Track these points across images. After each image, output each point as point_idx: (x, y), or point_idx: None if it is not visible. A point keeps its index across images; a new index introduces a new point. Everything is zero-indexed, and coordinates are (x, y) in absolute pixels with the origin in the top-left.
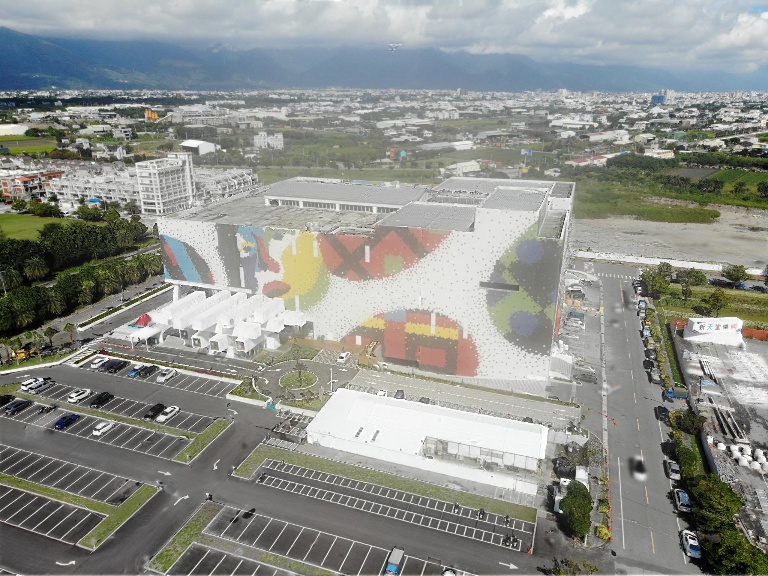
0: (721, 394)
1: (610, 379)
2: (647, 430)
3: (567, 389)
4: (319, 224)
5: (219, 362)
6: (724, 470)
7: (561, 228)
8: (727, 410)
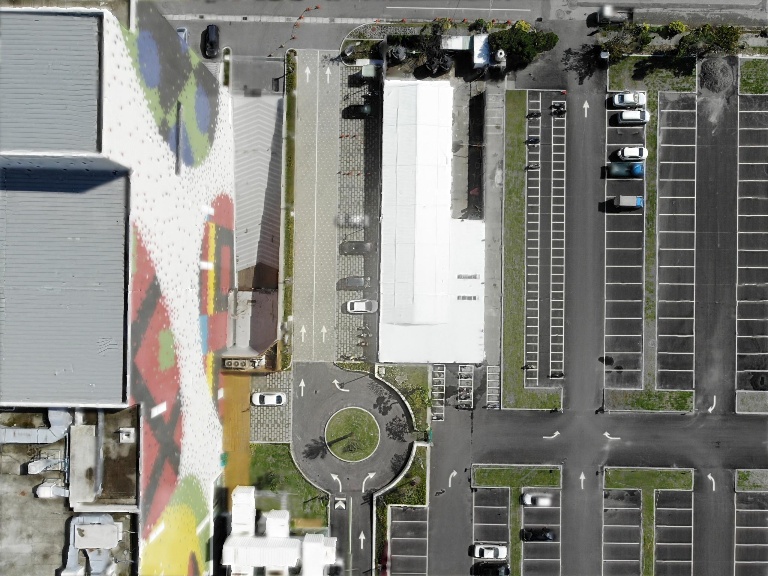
0: None
1: (195, 9)
2: None
3: (248, 68)
4: (74, 570)
5: (348, 573)
6: None
7: None
8: None
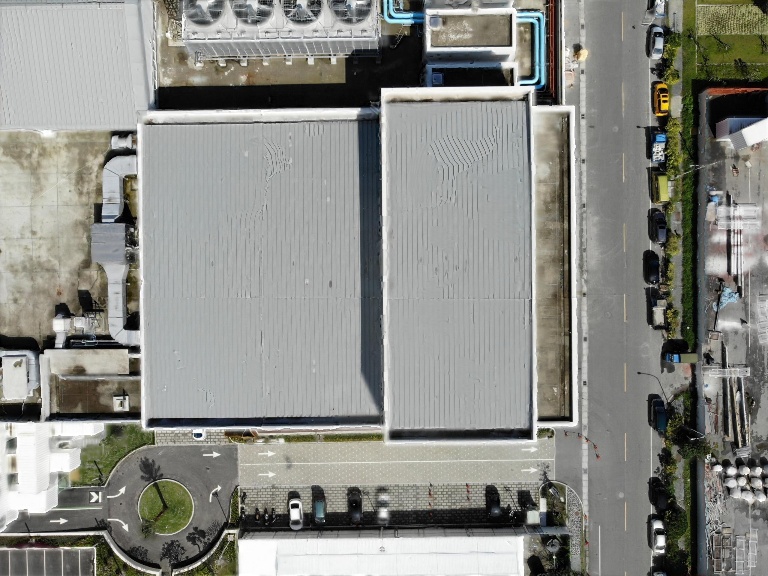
0: (740, 326)
1: (593, 333)
2: (635, 457)
3: None
4: None
5: None
6: (711, 515)
7: (566, 304)
8: (740, 379)
